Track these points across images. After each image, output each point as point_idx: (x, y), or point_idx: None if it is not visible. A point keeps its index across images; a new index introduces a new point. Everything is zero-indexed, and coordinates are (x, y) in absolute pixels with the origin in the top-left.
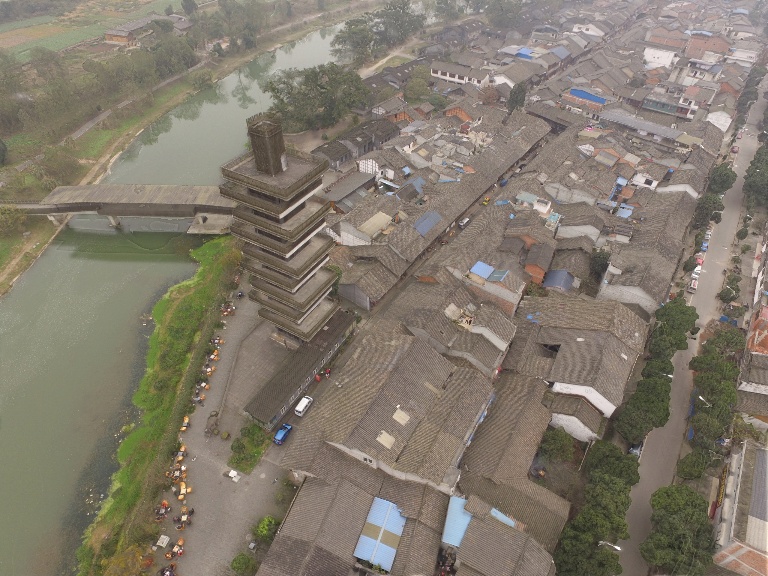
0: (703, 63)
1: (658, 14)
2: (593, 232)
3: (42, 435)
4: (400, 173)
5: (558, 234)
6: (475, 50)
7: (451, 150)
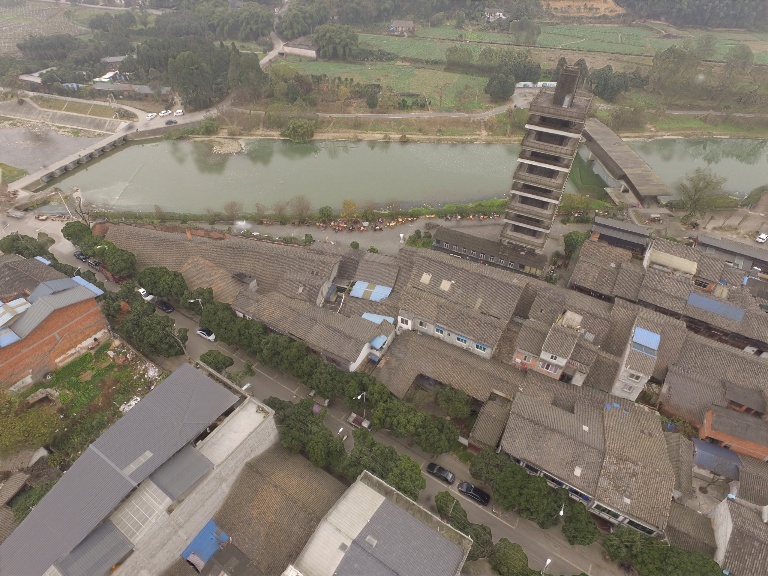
0: None
1: None
2: None
3: (419, 183)
4: None
5: None
6: None
7: None
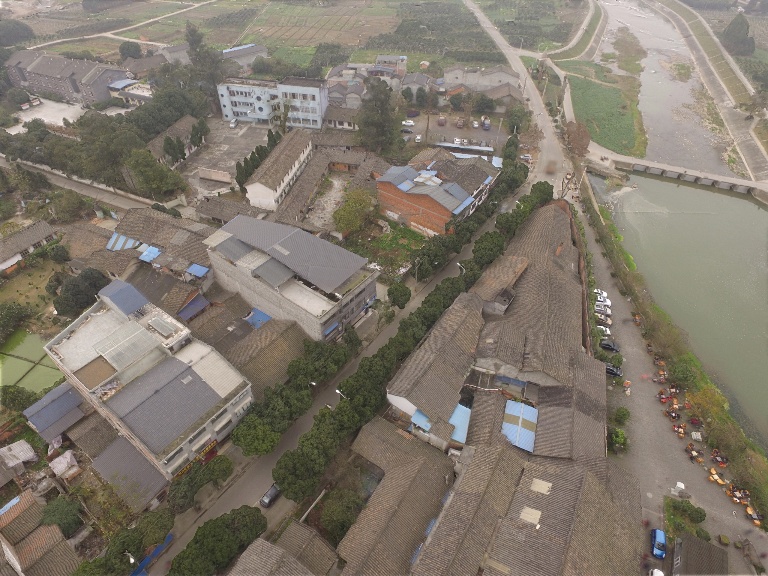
0: None
1: None
2: None
3: None
4: None
5: None
6: None
7: None
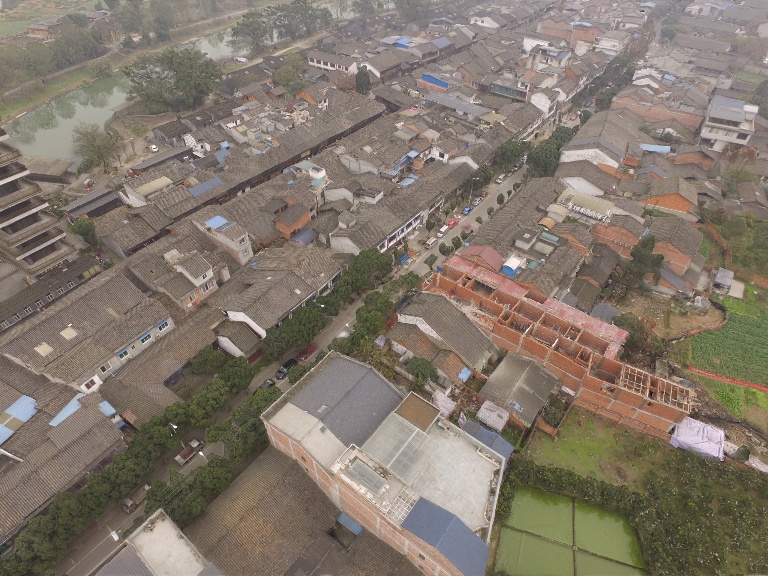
0: (550, 50)
1: (563, 7)
2: (348, 194)
3: None
4: (215, 146)
5: (326, 198)
6: (370, 41)
7: (267, 126)
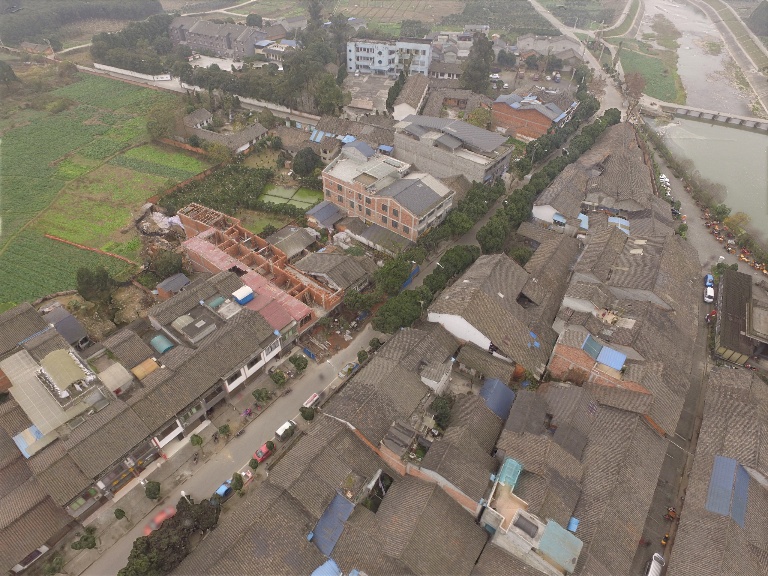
0: None
1: None
2: None
3: None
4: None
5: None
6: None
7: None
